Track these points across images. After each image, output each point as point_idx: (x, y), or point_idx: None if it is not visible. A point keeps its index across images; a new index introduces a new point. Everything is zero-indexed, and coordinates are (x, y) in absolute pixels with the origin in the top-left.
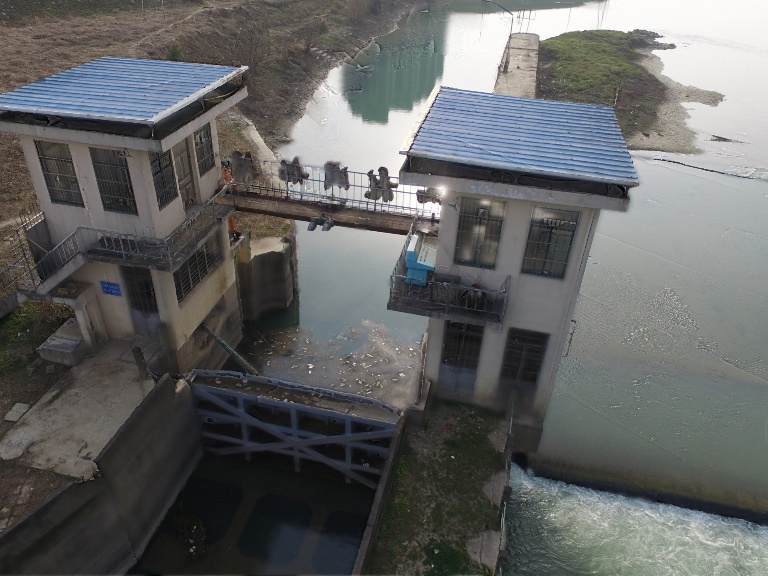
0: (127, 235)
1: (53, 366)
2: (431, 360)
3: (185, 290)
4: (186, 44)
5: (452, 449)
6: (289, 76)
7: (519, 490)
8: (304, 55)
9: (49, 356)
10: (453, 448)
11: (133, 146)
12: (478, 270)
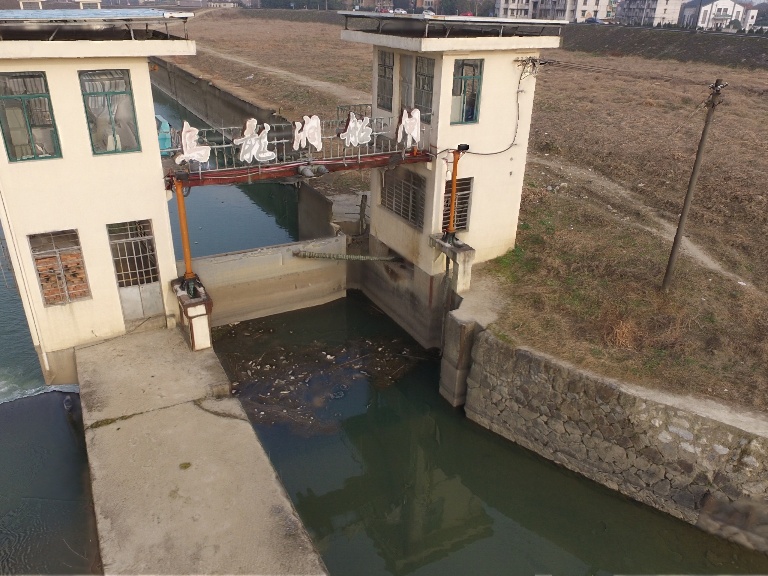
0: (367, 105)
1: None
2: None
3: None
4: None
5: None
6: None
7: (65, 386)
8: None
9: None
10: None
11: None
12: None
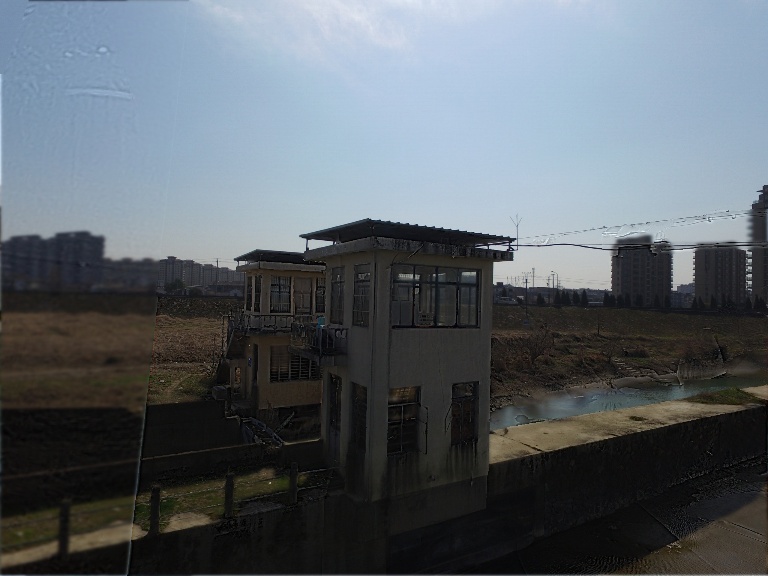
0: None
1: (210, 398)
2: (323, 418)
3: (282, 376)
4: (505, 341)
5: (278, 480)
6: (575, 370)
7: None
8: (605, 364)
9: (213, 393)
10: (279, 480)
11: (255, 267)
12: (337, 326)
